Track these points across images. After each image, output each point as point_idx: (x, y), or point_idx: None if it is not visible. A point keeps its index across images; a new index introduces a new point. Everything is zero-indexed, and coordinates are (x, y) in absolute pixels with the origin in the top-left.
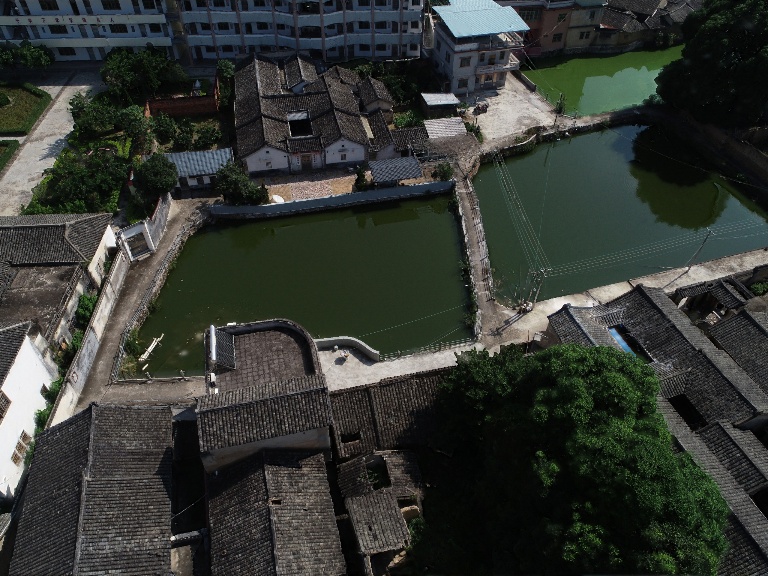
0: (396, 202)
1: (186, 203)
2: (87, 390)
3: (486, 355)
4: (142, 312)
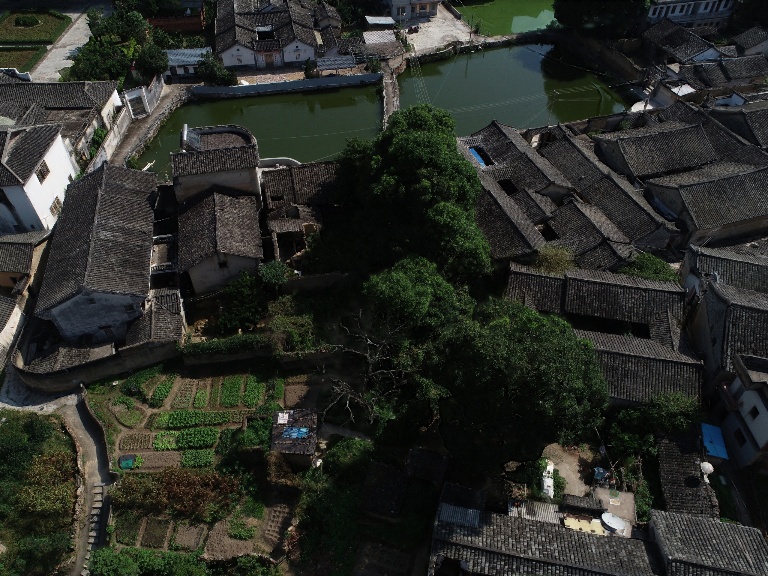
0: (337, 89)
1: (175, 87)
2: None
3: (367, 141)
4: (140, 147)
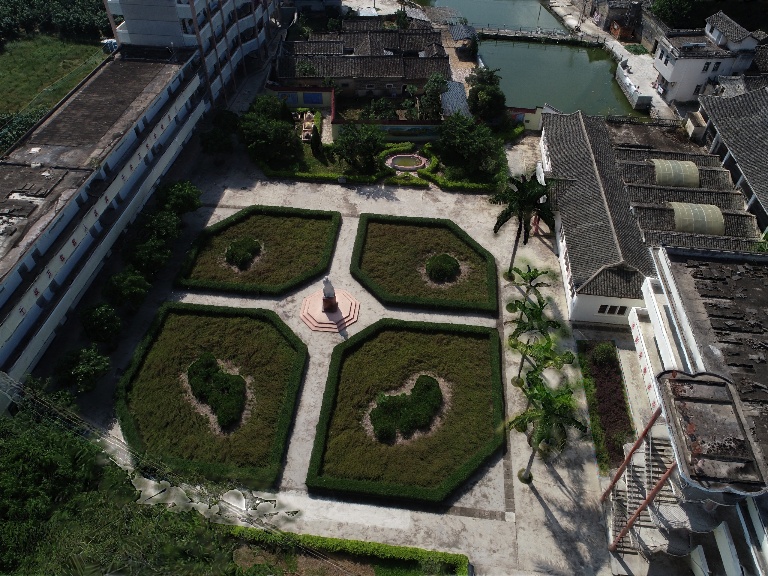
0: None
1: None
2: None
3: None
4: None
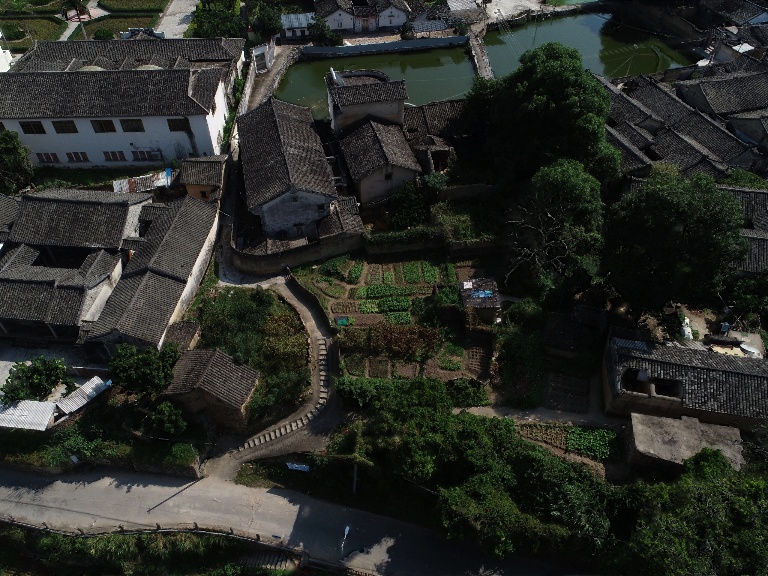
0: (428, 50)
1: (285, 47)
2: None
3: None
4: None
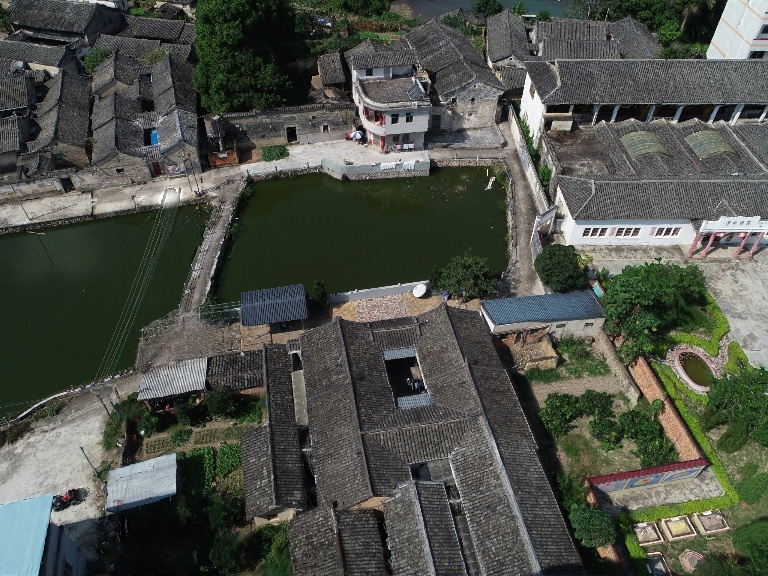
0: None
1: None
2: (516, 155)
3: (260, 82)
4: None
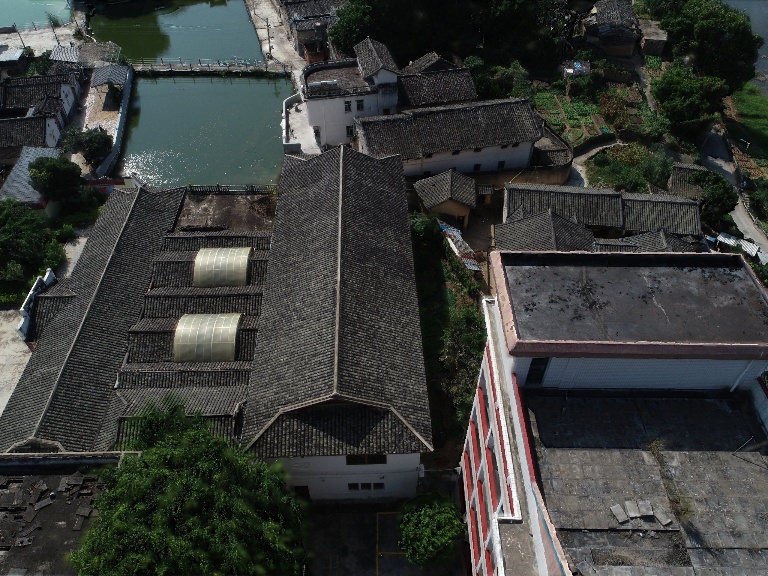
0: (133, 98)
1: None
2: None
3: None
4: None
